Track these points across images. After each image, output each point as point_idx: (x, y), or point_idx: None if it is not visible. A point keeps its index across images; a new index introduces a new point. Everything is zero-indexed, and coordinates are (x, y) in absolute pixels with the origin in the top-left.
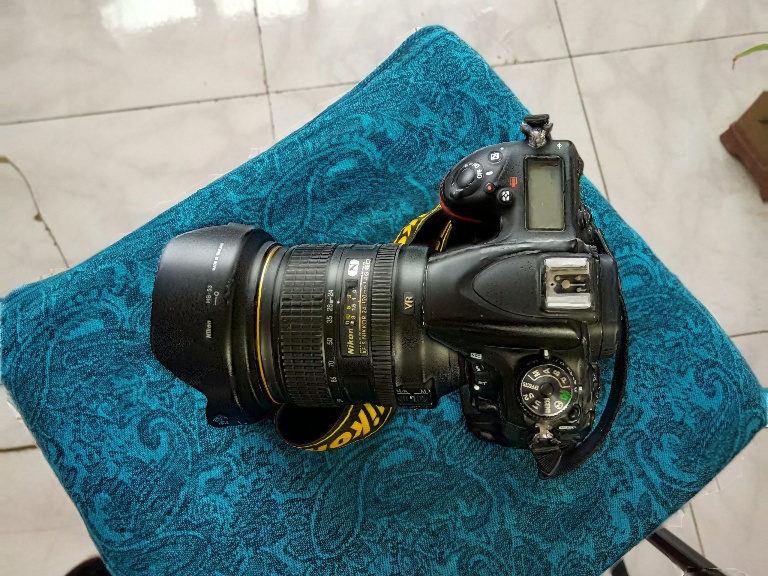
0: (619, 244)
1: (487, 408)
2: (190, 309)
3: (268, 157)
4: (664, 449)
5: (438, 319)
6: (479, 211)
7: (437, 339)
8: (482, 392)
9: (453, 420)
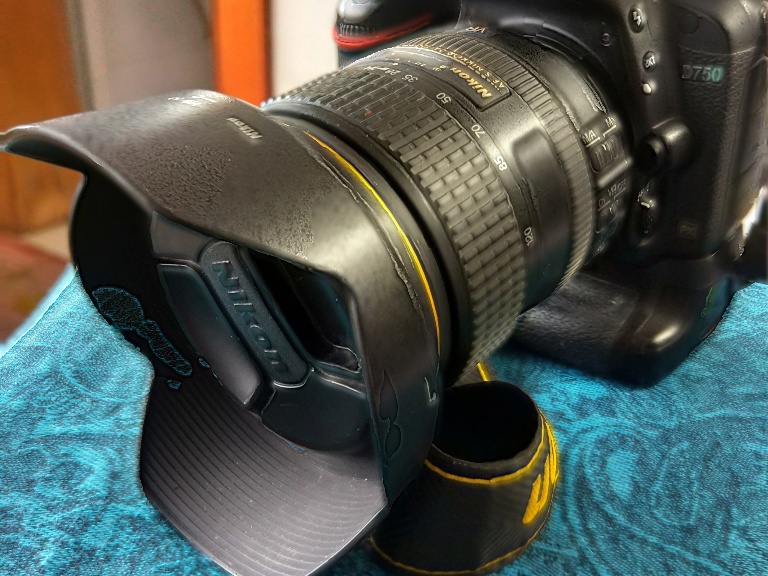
0: None
1: (672, 141)
2: (170, 119)
3: (12, 353)
4: (764, 287)
5: None
6: (418, 5)
7: None
8: (652, 107)
9: (601, 393)
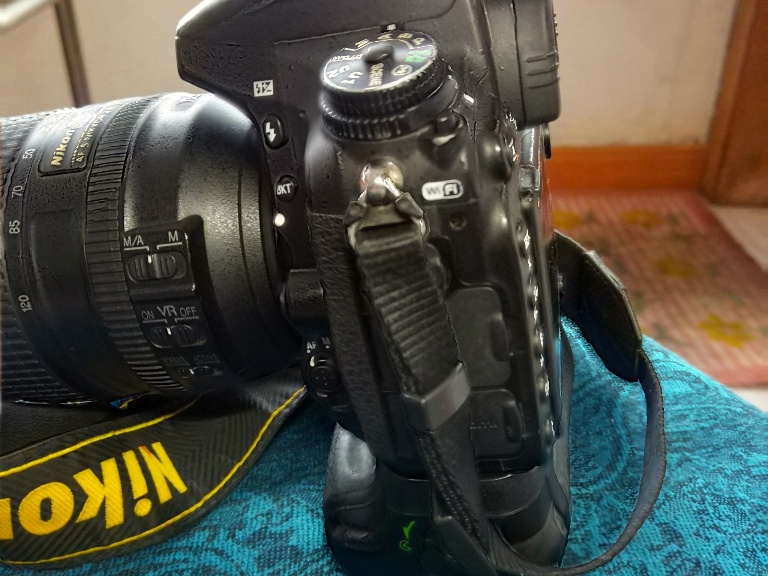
0: (645, 348)
1: (307, 296)
2: None
3: None
4: None
5: (200, 23)
6: None
7: (194, 64)
8: (295, 246)
9: (308, 545)
